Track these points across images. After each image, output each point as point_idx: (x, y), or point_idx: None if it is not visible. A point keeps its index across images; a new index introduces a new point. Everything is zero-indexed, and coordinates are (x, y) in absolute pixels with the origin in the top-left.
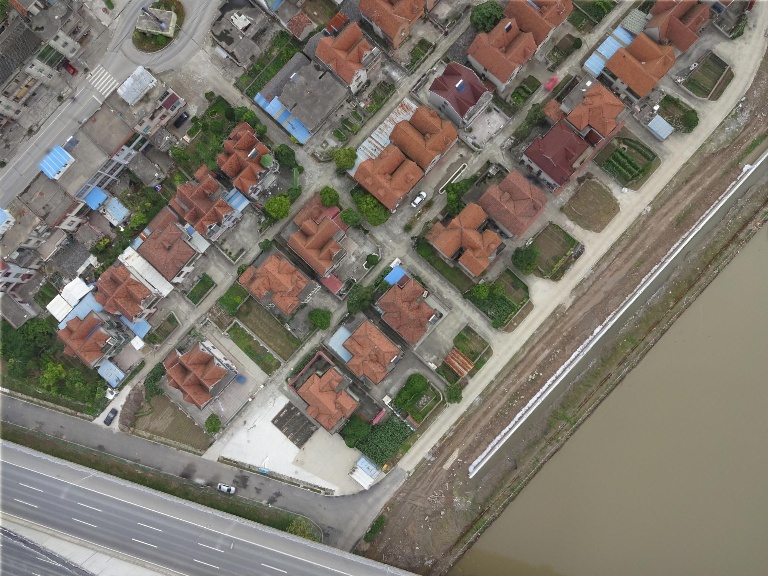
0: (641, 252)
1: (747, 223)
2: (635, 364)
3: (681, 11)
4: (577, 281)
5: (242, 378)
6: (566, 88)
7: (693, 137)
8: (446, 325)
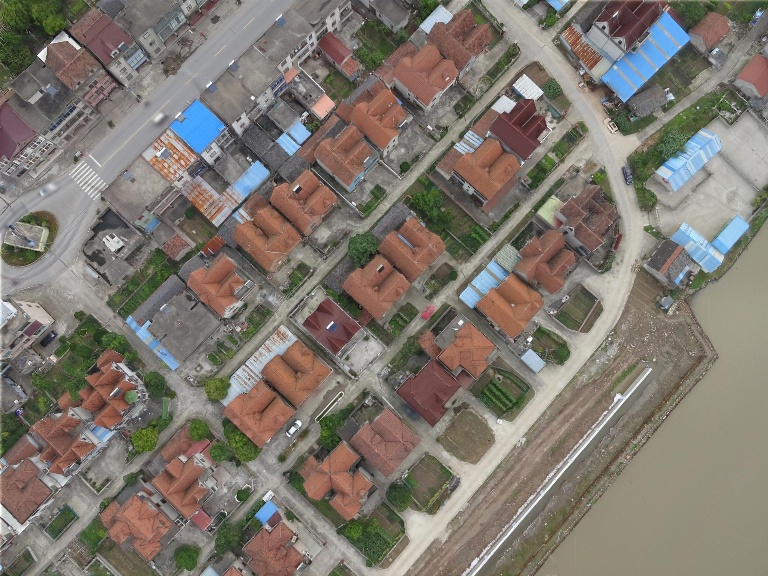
0: (516, 483)
1: (618, 455)
2: None
3: (548, 257)
4: (453, 515)
5: None
6: (442, 318)
7: (565, 369)
8: (320, 561)
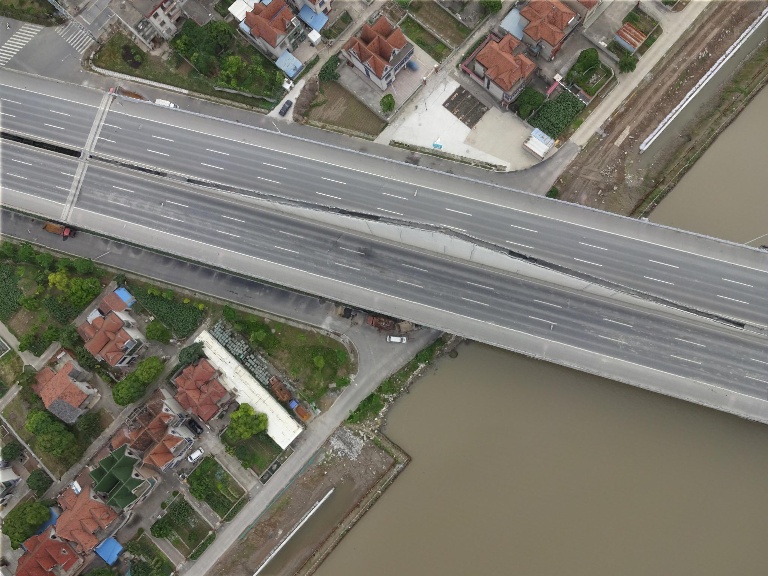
0: None
1: None
2: None
3: None
4: None
5: (413, 67)
6: None
7: None
8: (614, 8)
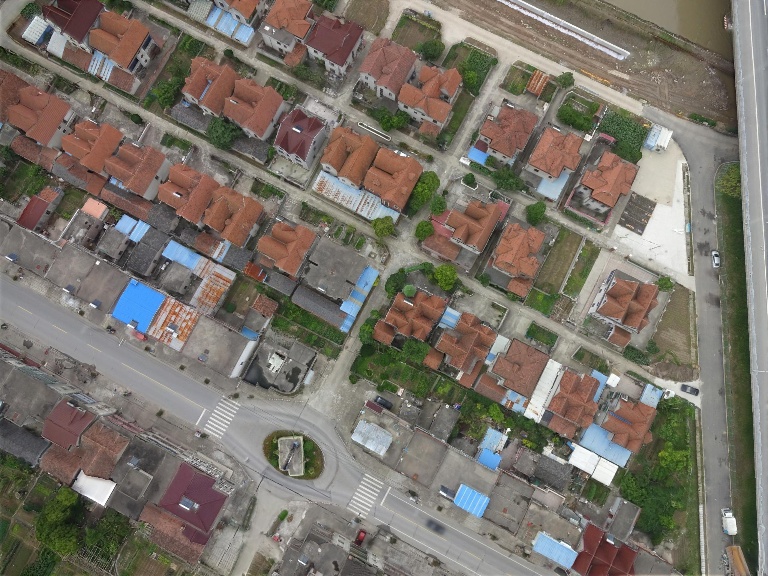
0: None
1: None
2: None
3: None
4: (436, 8)
5: None
6: None
7: None
8: None
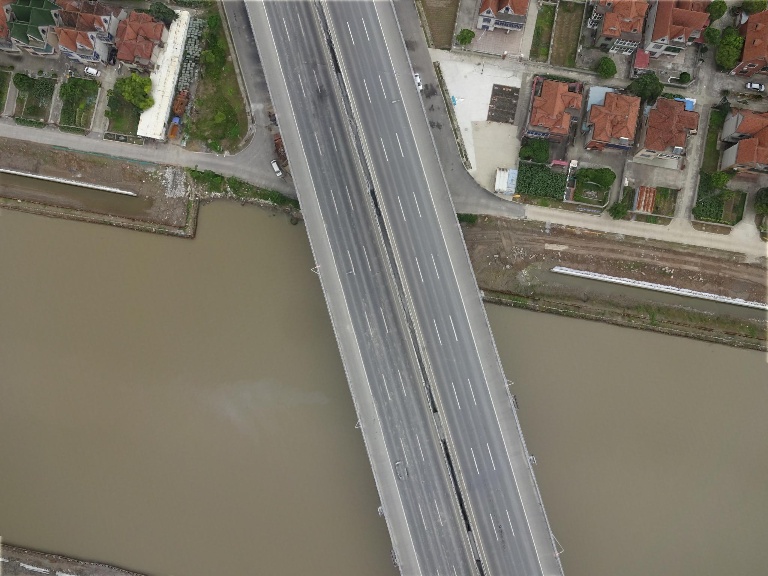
0: None
1: None
2: (735, 345)
3: None
4: None
5: (513, 39)
6: None
7: None
8: (666, 173)
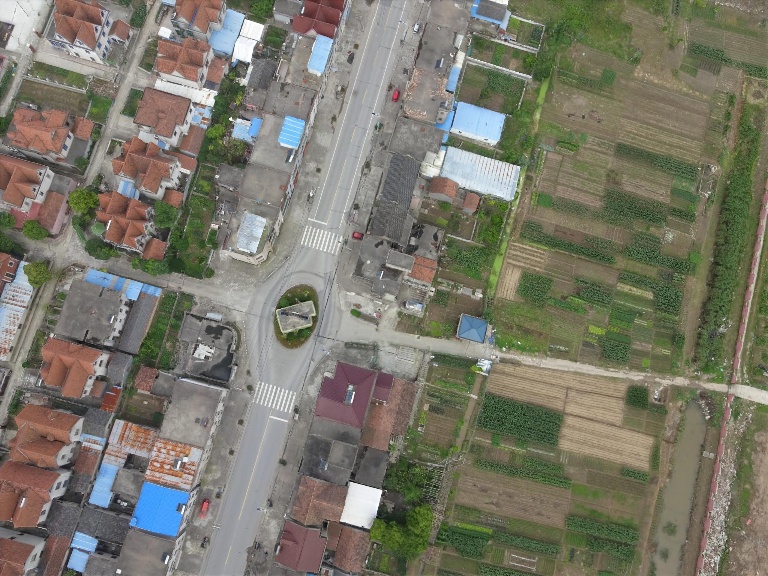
0: None
1: None
2: None
3: None
4: None
5: None
6: None
7: None
8: None
